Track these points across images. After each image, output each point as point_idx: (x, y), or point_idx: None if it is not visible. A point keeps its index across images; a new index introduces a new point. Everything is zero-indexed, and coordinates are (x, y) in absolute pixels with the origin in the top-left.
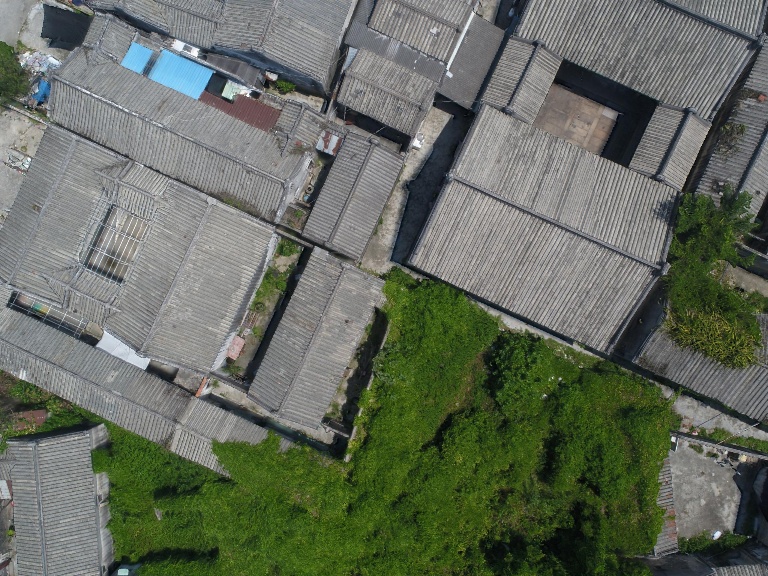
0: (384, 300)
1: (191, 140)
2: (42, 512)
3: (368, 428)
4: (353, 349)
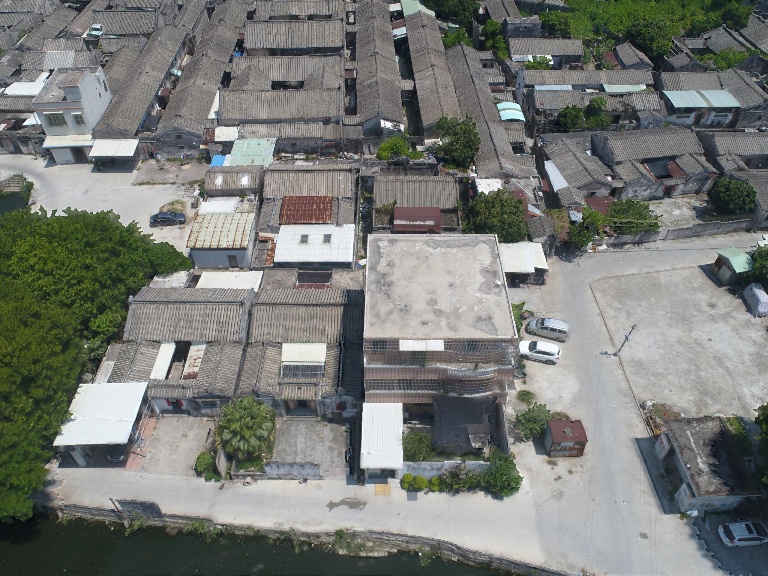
0: None
1: None
2: (504, 3)
3: (615, 5)
4: None
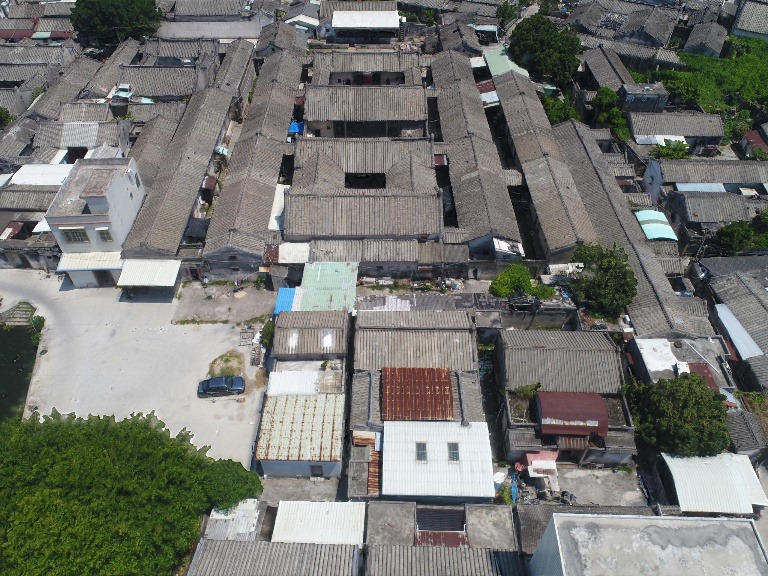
0: (728, 38)
1: (640, 3)
2: None
3: None
4: (723, 42)
